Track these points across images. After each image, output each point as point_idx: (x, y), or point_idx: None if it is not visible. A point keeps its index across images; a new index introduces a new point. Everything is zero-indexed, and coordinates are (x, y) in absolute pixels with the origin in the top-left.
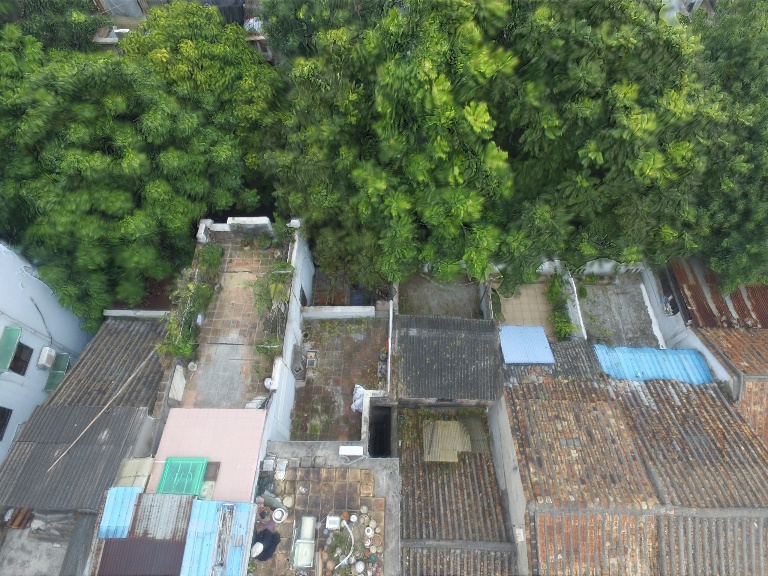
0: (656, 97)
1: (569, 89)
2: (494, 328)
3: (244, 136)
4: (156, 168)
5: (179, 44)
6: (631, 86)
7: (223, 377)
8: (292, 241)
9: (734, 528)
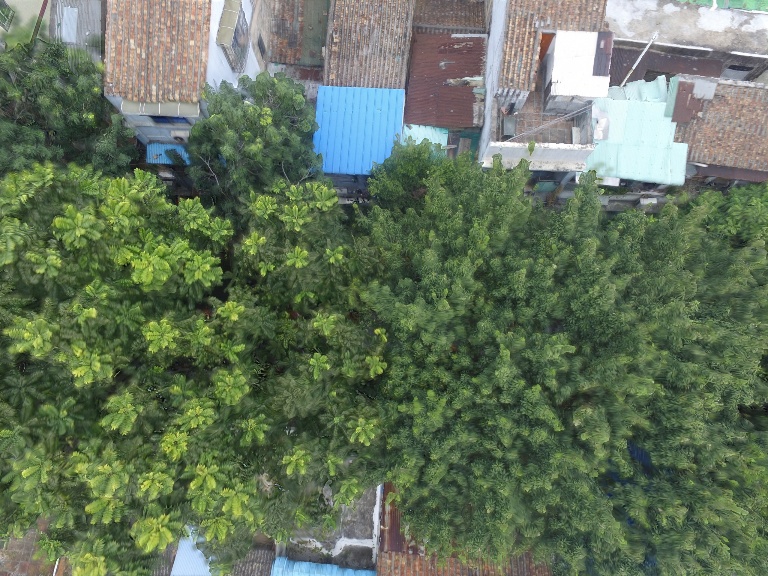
0: (141, 523)
1: None
2: None
3: None
4: None
5: None
6: None
7: None
8: None
9: None
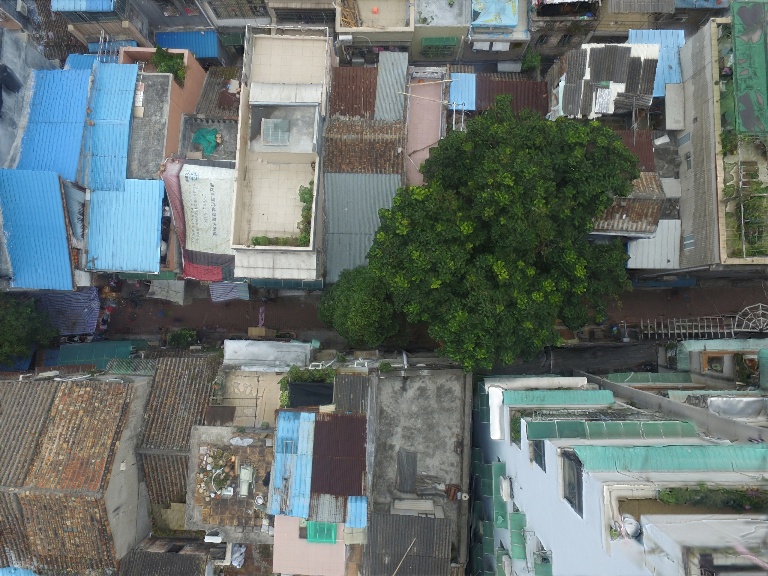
0: None
1: None
2: None
3: None
4: None
5: None
6: None
7: None
8: None
9: None
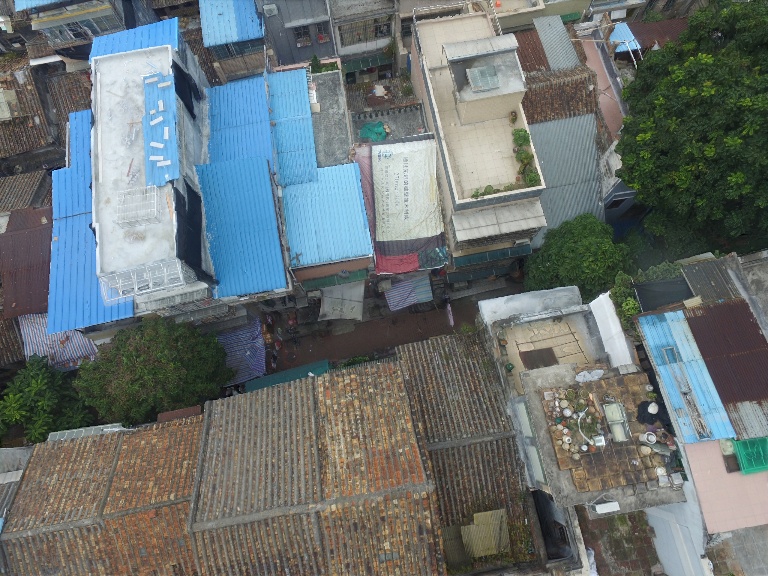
0: None
1: None
2: None
3: None
4: None
5: None
6: None
7: (759, 562)
8: None
9: (258, 502)
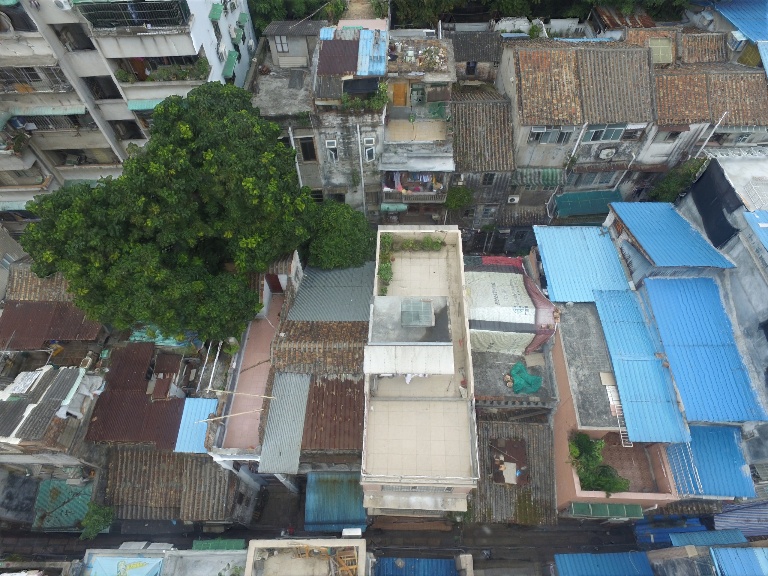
0: None
1: None
2: (497, 30)
3: None
4: None
5: None
6: None
7: None
8: None
9: (613, 56)
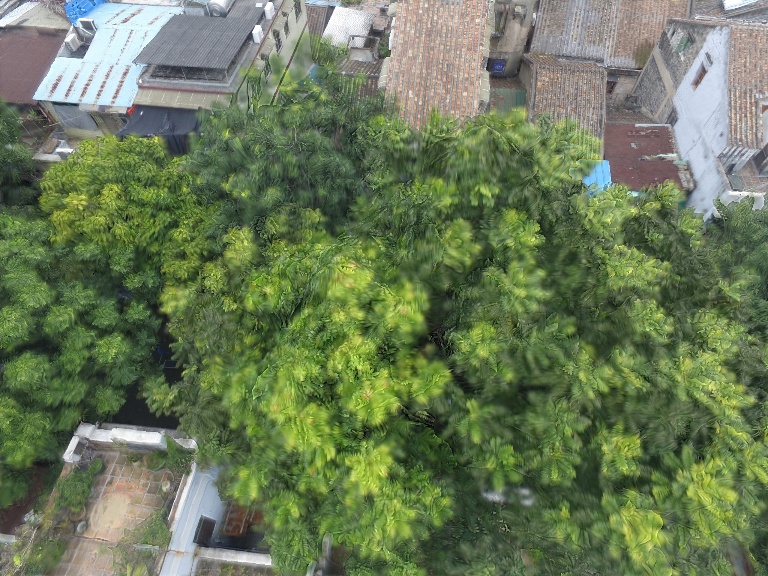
0: (680, 465)
1: (538, 438)
2: None
3: (173, 294)
4: (7, 381)
5: (102, 190)
6: (640, 435)
7: None
8: (187, 471)
9: None
